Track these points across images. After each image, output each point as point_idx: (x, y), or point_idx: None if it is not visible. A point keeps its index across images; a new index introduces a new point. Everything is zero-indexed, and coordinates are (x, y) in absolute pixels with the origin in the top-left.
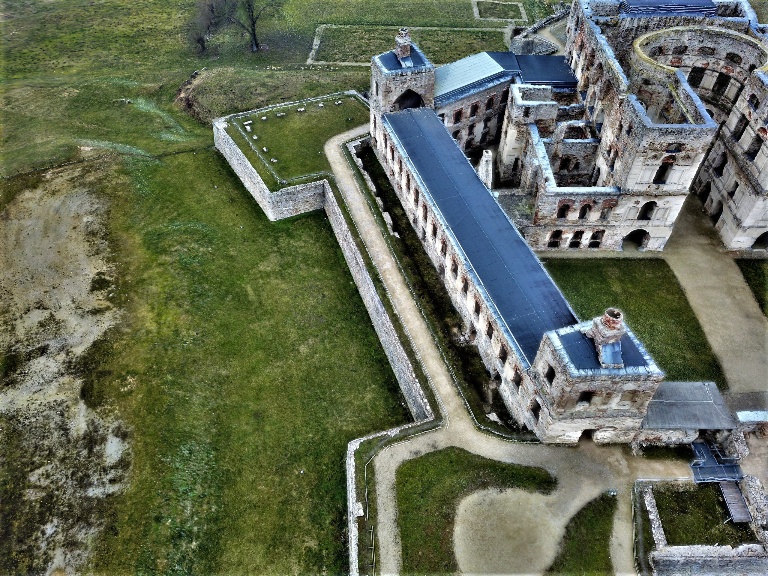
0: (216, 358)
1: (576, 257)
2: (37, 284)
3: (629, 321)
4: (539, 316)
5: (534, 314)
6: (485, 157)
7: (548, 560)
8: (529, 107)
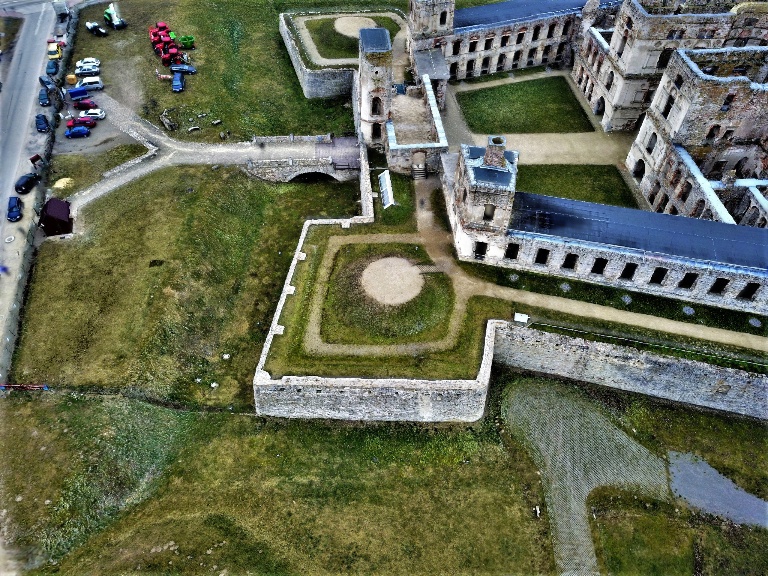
0: None
1: (576, 95)
2: None
3: (519, 106)
4: (470, 15)
5: None
6: None
7: (346, 34)
8: None
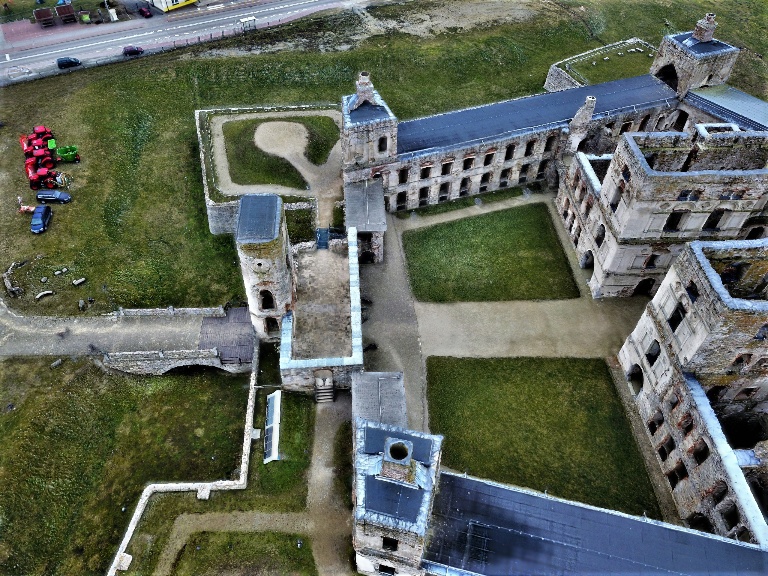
0: (409, 74)
1: (559, 235)
2: (448, 13)
3: (483, 253)
4: (422, 132)
5: (424, 130)
6: (586, 99)
7: (266, 149)
8: (698, 133)
